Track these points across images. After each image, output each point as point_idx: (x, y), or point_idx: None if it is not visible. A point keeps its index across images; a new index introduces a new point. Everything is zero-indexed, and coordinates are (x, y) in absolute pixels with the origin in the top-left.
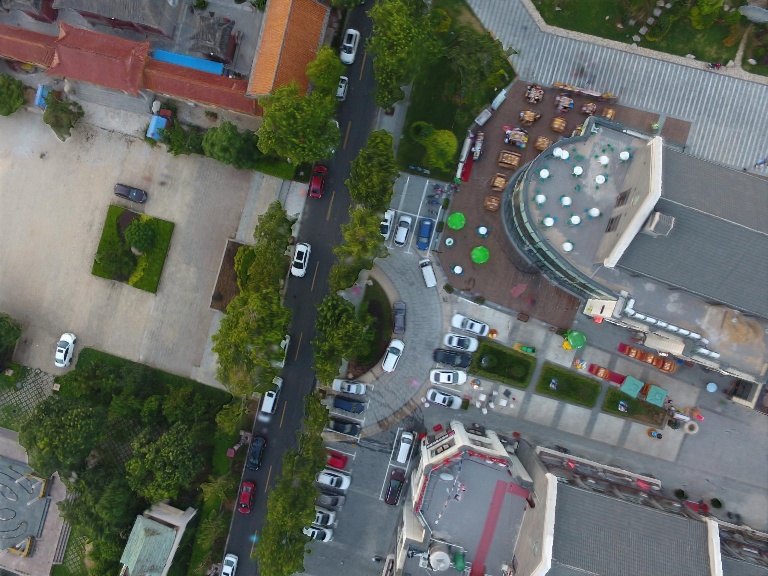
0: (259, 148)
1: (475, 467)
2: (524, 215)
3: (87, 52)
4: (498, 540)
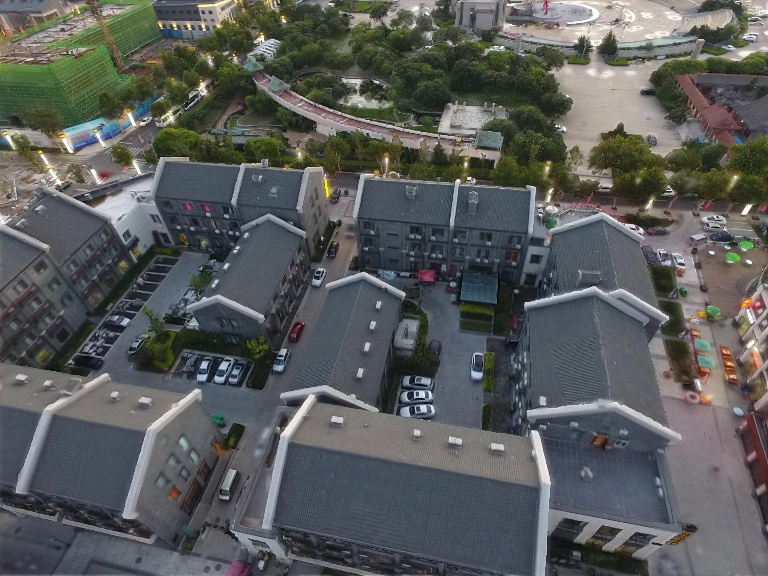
0: None
1: None
2: None
3: None
4: None
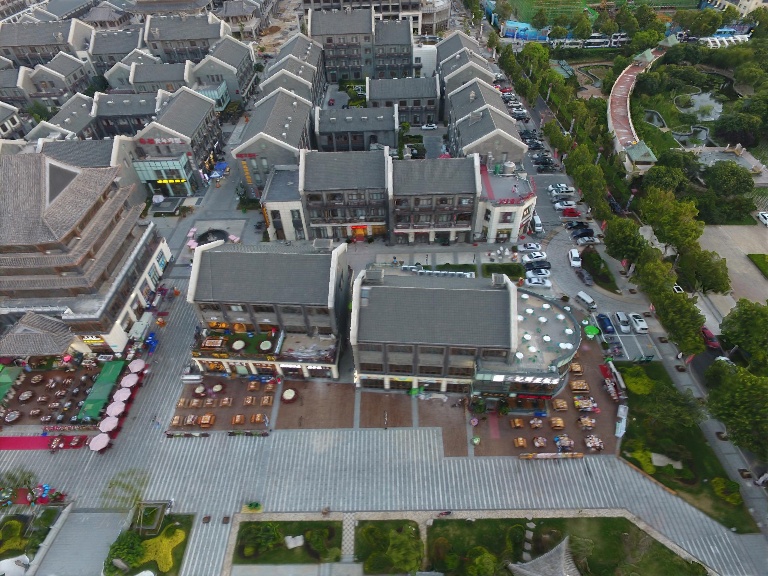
0: None
1: None
2: None
3: None
4: (481, 182)
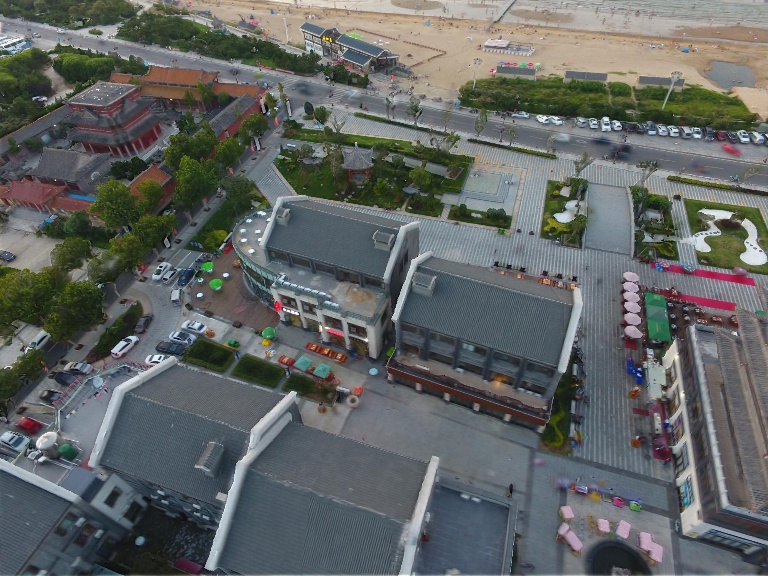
0: (88, 210)
1: None
2: None
3: (27, 185)
4: None
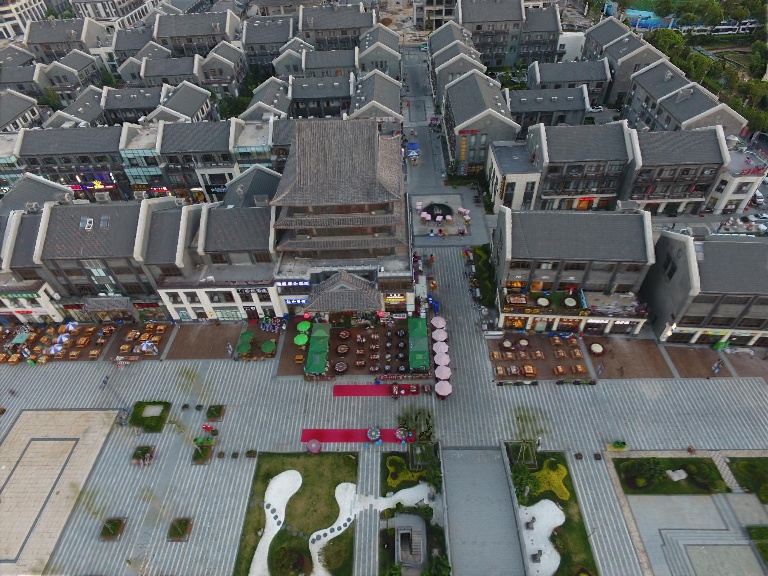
0: None
1: None
2: None
3: None
4: None
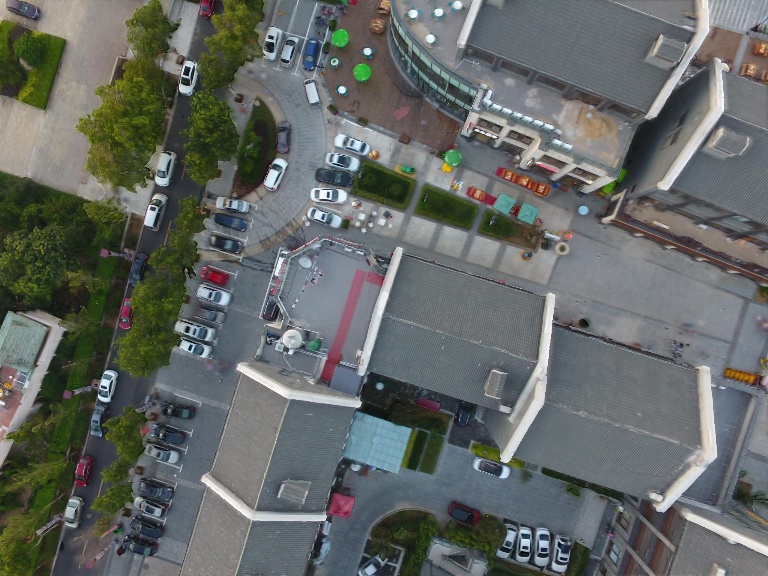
0: None
1: (335, 257)
2: (391, 10)
3: None
4: (355, 329)
